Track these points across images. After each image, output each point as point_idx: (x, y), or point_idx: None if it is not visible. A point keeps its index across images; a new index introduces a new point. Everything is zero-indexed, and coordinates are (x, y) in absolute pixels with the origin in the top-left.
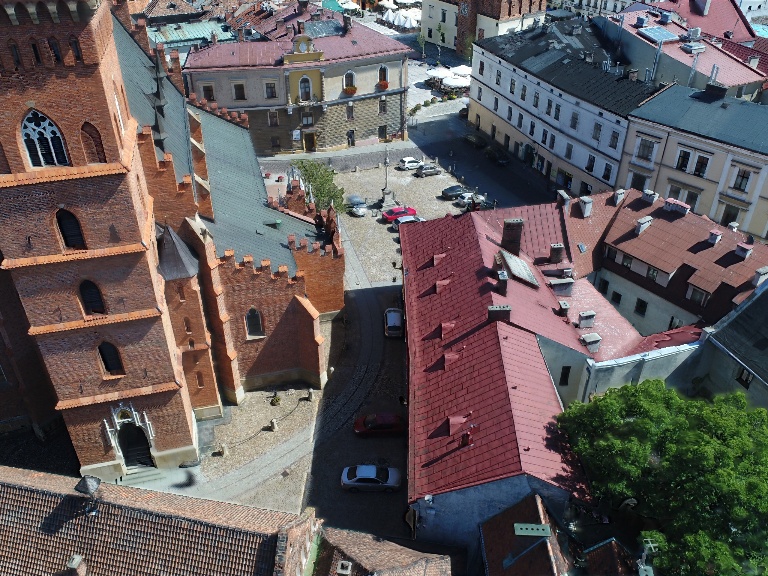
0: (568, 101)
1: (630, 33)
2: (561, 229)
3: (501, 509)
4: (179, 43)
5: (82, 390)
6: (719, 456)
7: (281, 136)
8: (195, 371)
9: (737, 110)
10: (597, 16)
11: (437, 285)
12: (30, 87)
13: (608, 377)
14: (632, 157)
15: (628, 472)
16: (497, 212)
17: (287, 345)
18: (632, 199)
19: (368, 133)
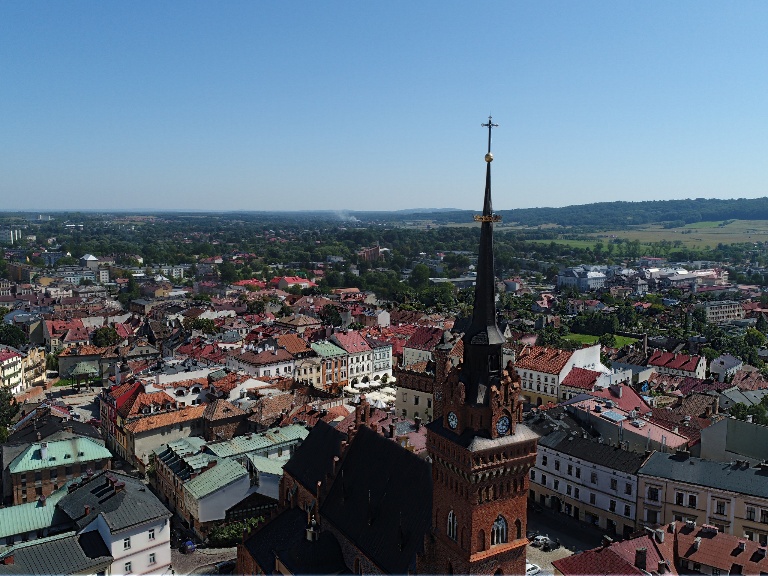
0: (586, 466)
1: (596, 416)
2: (657, 551)
3: None
4: (284, 444)
5: None
6: None
7: None
8: None
9: (701, 465)
10: (569, 406)
11: None
12: (502, 504)
13: None
14: (645, 499)
15: None
16: (621, 545)
17: None
18: (680, 527)
19: None
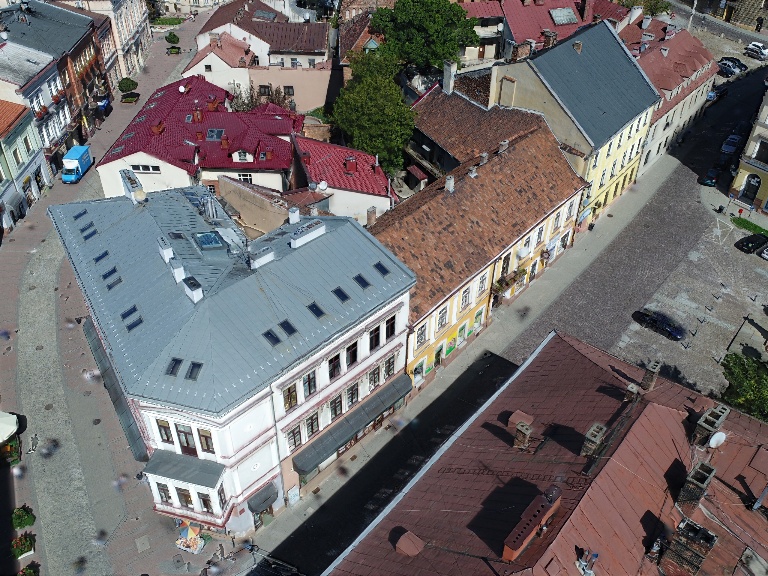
0: None
1: None
2: None
3: None
4: None
5: None
6: None
7: (715, 1)
8: None
9: None
10: None
11: None
12: None
13: None
14: None
15: None
16: None
17: None
18: None
19: None
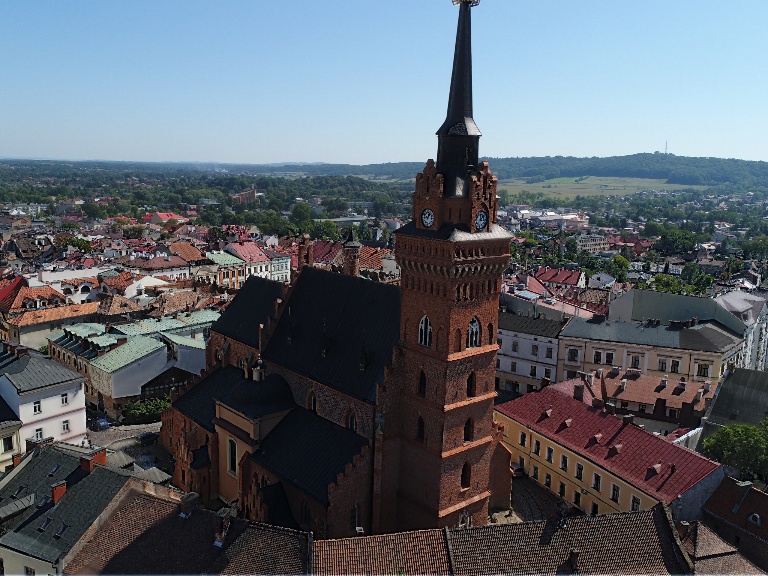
0: (508, 335)
1: (511, 296)
2: (589, 391)
3: (712, 493)
4: (197, 326)
5: (450, 501)
6: None
7: None
8: None
9: (616, 326)
10: None
11: (567, 423)
12: (477, 305)
13: None
14: (565, 361)
15: (763, 450)
16: (558, 385)
17: (491, 480)
18: (606, 373)
19: None
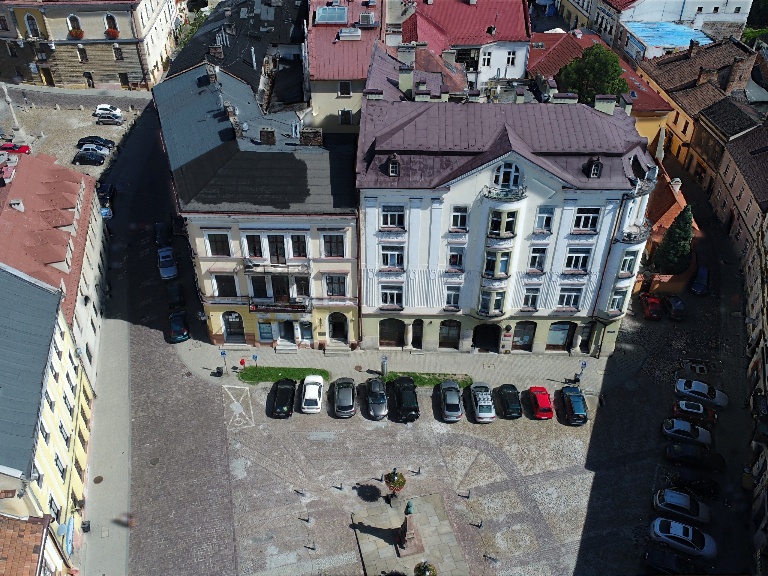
0: None
1: None
2: None
3: None
4: None
5: None
6: None
7: (22, 67)
8: None
9: (202, 98)
10: None
11: None
12: None
13: None
14: None
15: None
16: None
17: None
18: None
19: (108, 77)
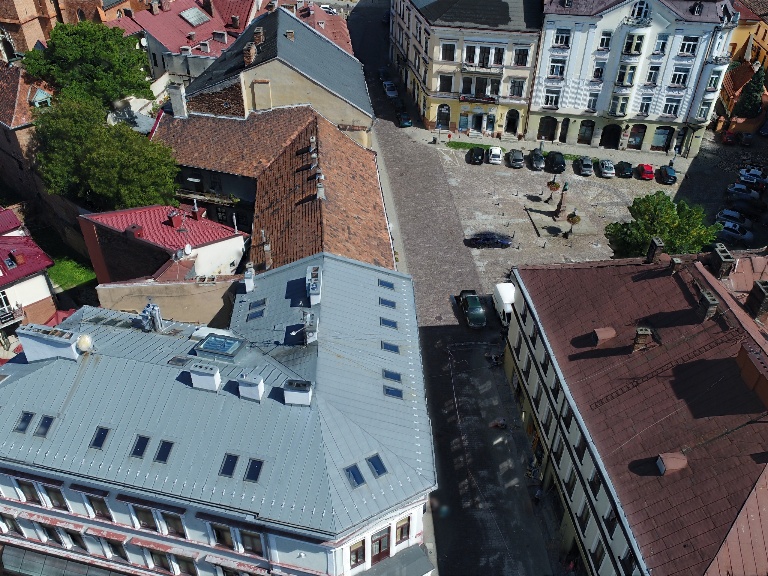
0: None
1: None
2: None
3: None
4: None
5: None
6: (64, 28)
7: None
8: (47, 31)
9: None
10: None
11: None
12: None
13: (172, 62)
14: (391, 7)
15: None
16: None
17: None
18: (306, 7)
19: None
